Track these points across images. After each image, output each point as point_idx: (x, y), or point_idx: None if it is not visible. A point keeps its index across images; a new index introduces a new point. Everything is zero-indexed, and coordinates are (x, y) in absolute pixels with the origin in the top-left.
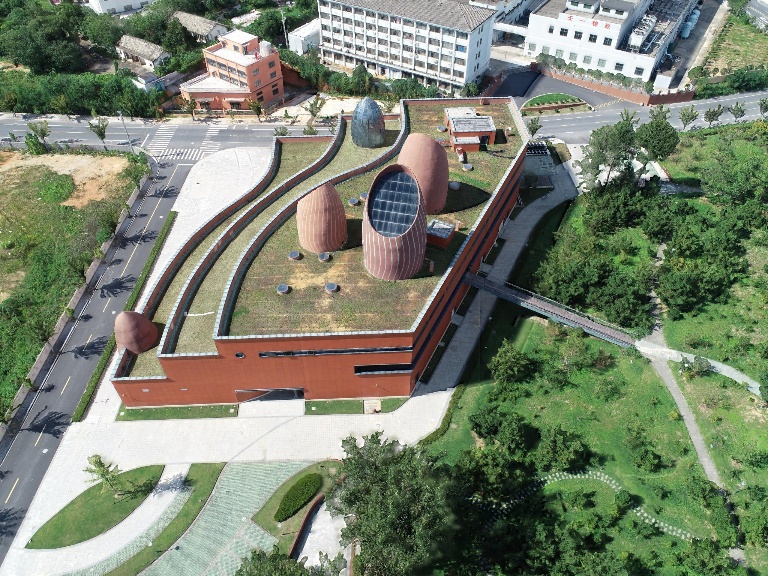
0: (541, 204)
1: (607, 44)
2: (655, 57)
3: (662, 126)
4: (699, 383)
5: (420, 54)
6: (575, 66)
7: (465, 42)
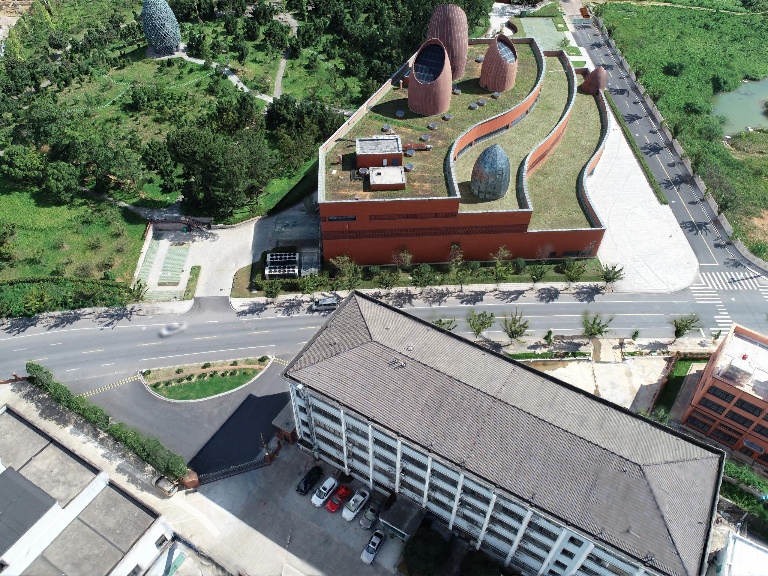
0: (301, 212)
1: None
2: None
3: None
4: None
5: None
6: None
7: None
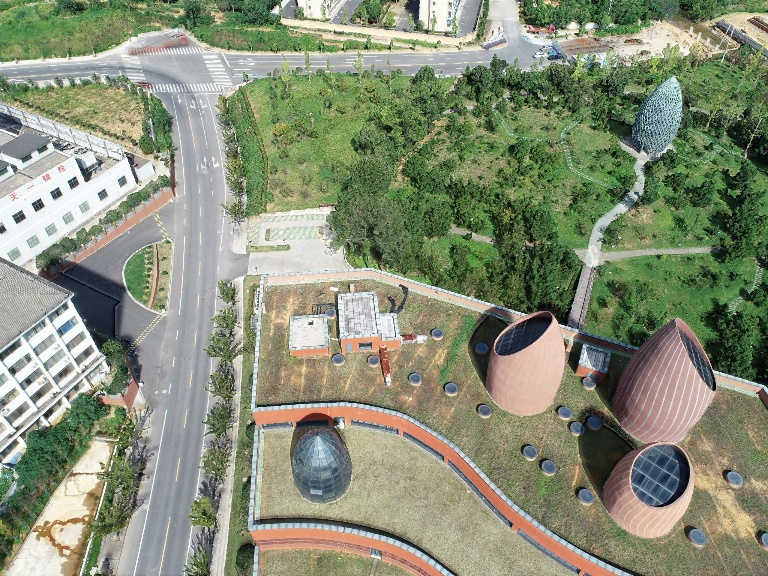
0: None
1: (74, 186)
2: (125, 157)
3: (375, 162)
4: (623, 239)
5: (8, 403)
6: (85, 231)
7: (68, 314)
